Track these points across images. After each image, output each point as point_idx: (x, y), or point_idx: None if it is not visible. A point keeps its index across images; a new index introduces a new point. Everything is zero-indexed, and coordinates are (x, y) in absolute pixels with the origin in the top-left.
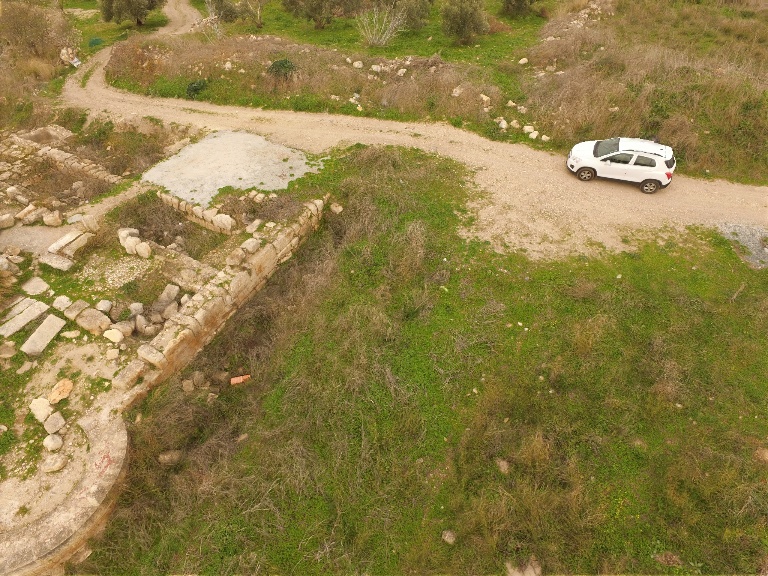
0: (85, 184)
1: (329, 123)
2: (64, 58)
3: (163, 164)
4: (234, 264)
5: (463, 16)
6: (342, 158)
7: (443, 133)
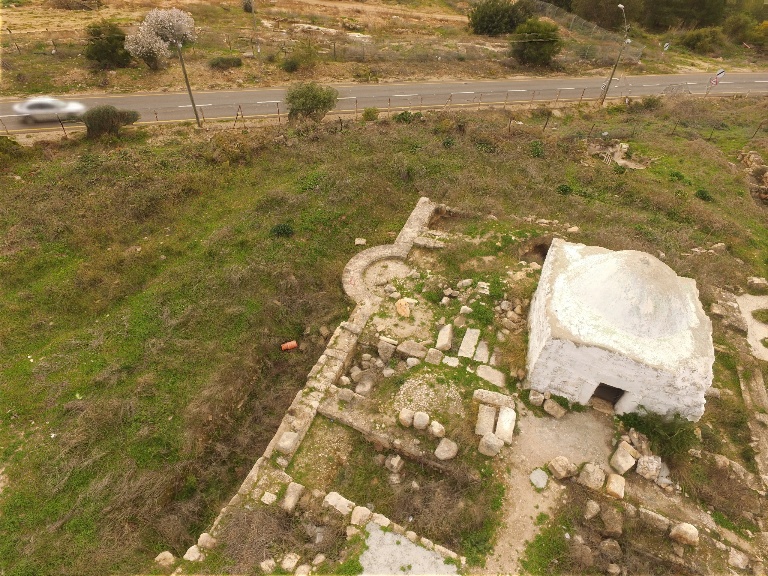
0: None
1: None
2: None
3: None
4: None
5: None
6: None
7: None
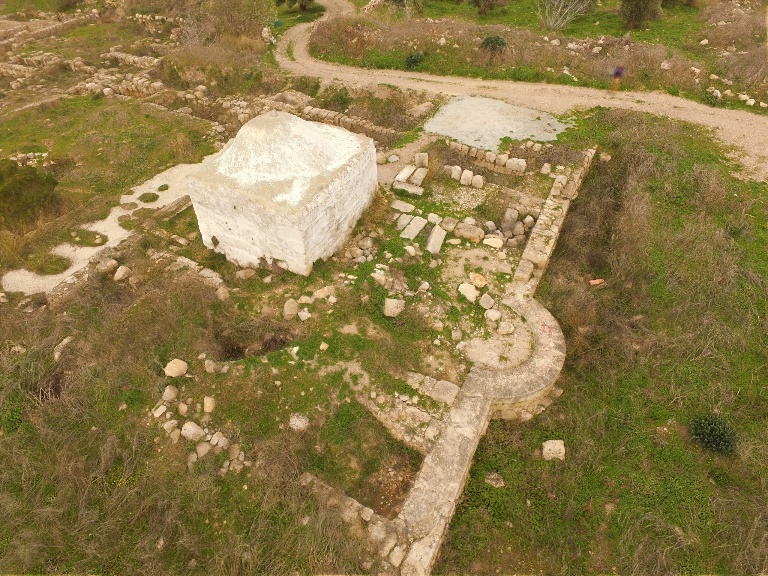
0: (371, 135)
1: (552, 91)
2: (266, 35)
3: (434, 119)
4: (557, 194)
5: (646, 1)
6: (590, 117)
7: (664, 100)
